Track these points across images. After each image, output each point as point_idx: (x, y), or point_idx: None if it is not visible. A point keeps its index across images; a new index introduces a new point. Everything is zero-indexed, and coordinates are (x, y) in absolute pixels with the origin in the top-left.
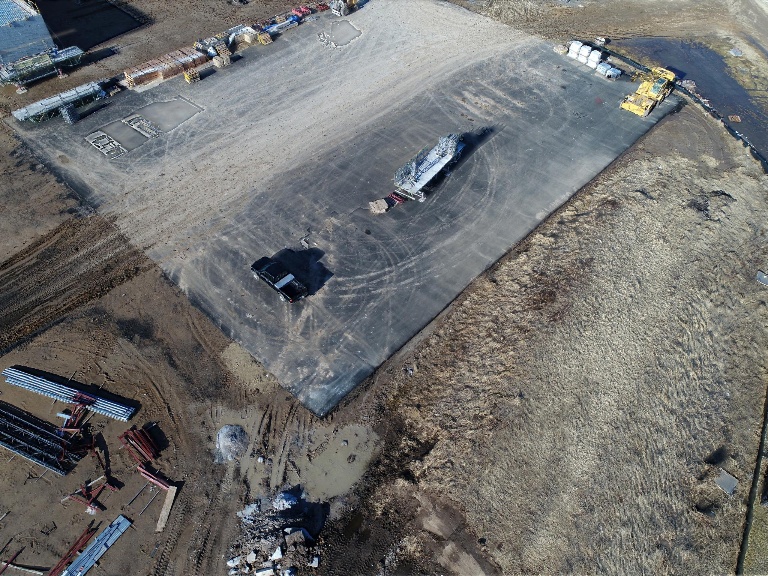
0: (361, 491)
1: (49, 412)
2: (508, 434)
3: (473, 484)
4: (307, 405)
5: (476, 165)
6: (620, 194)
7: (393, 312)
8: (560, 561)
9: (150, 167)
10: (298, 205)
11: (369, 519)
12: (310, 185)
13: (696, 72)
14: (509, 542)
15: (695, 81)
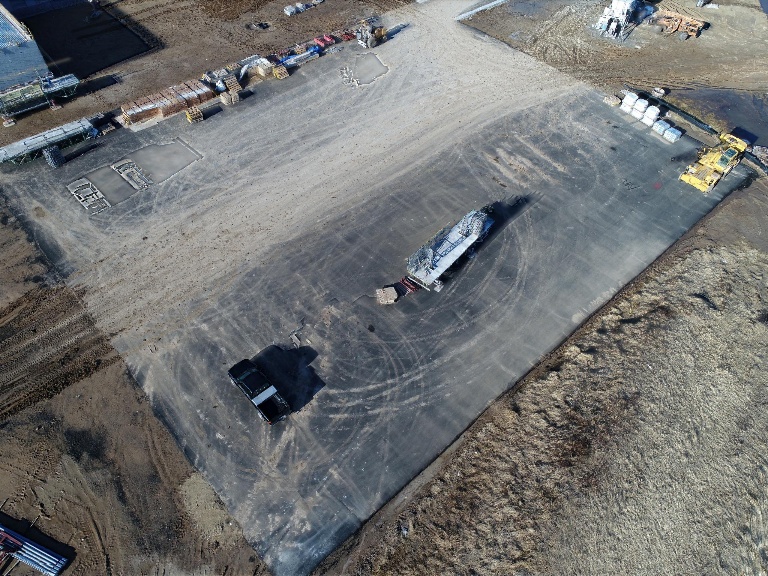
0: None
1: None
2: None
3: None
4: (274, 571)
5: (505, 245)
6: (676, 298)
7: (391, 442)
8: None
9: (133, 228)
10: (294, 287)
11: None
12: (310, 261)
13: None
14: None
15: None
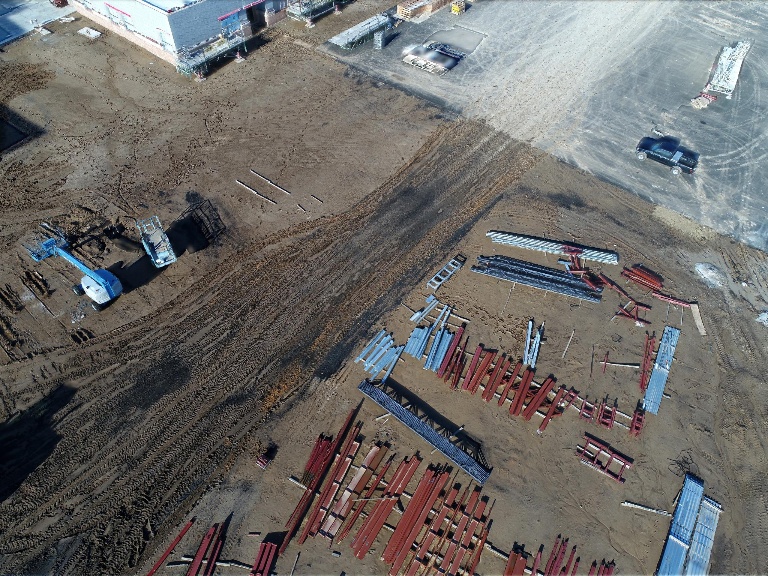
0: None
1: (547, 261)
2: None
3: None
4: (752, 245)
5: (753, 70)
6: None
7: None
8: None
9: (480, 81)
10: (630, 105)
11: None
12: (628, 89)
13: None
14: None
15: None
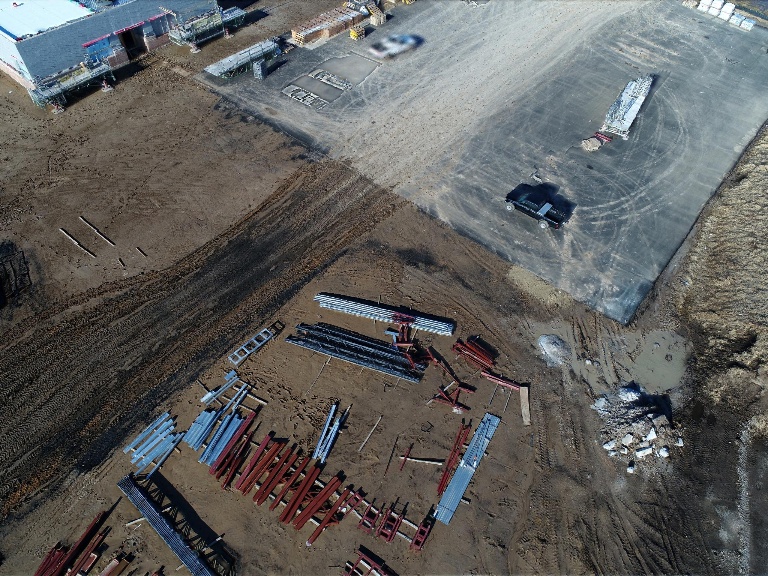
0: (691, 383)
1: (374, 331)
2: None
3: None
4: (608, 315)
5: (660, 107)
6: None
7: (646, 235)
8: None
9: (358, 116)
10: (515, 146)
11: (710, 405)
12: (517, 128)
13: None
14: None
15: None
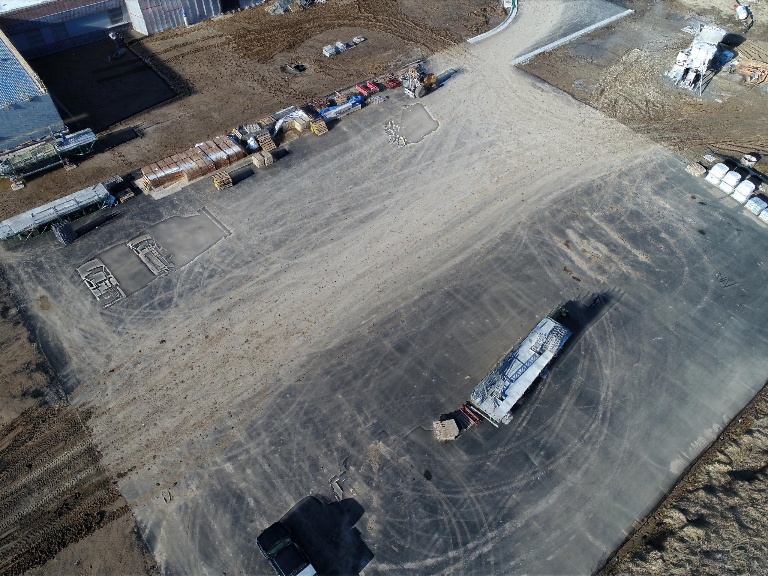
0: None
1: None
2: None
3: None
4: None
5: (583, 361)
6: None
7: None
8: None
9: (149, 326)
10: (335, 414)
11: None
12: (354, 378)
13: None
14: None
15: None
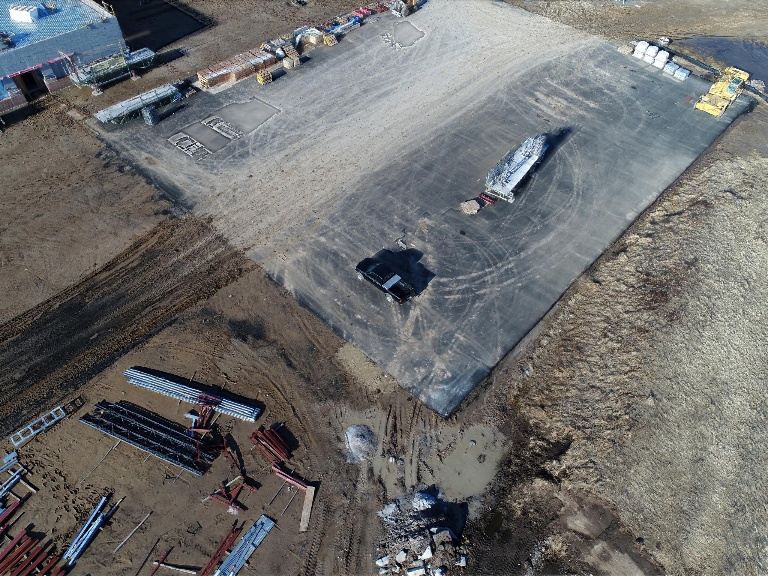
0: (496, 491)
1: (176, 413)
2: (647, 434)
3: (621, 484)
4: (430, 405)
5: (559, 166)
6: (710, 194)
7: (500, 312)
8: (721, 560)
9: (237, 168)
10: (389, 206)
11: (509, 519)
12: (398, 186)
13: (762, 72)
14: (667, 541)
15: (763, 81)
